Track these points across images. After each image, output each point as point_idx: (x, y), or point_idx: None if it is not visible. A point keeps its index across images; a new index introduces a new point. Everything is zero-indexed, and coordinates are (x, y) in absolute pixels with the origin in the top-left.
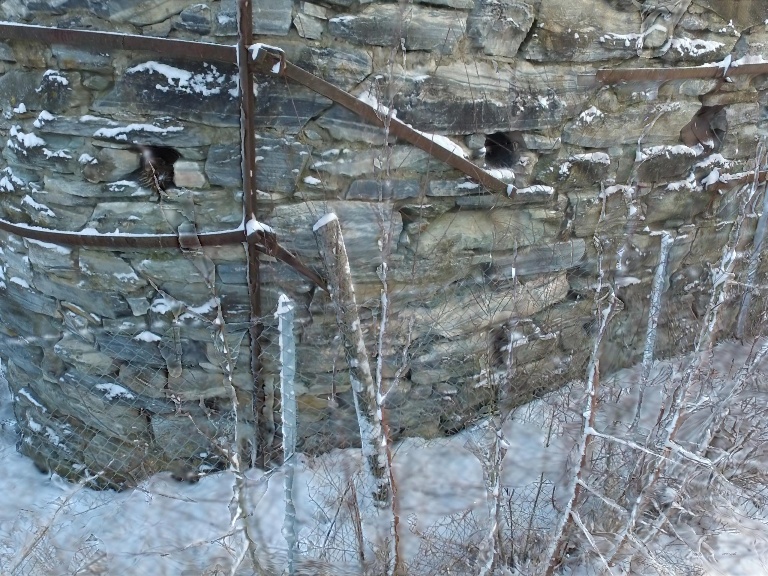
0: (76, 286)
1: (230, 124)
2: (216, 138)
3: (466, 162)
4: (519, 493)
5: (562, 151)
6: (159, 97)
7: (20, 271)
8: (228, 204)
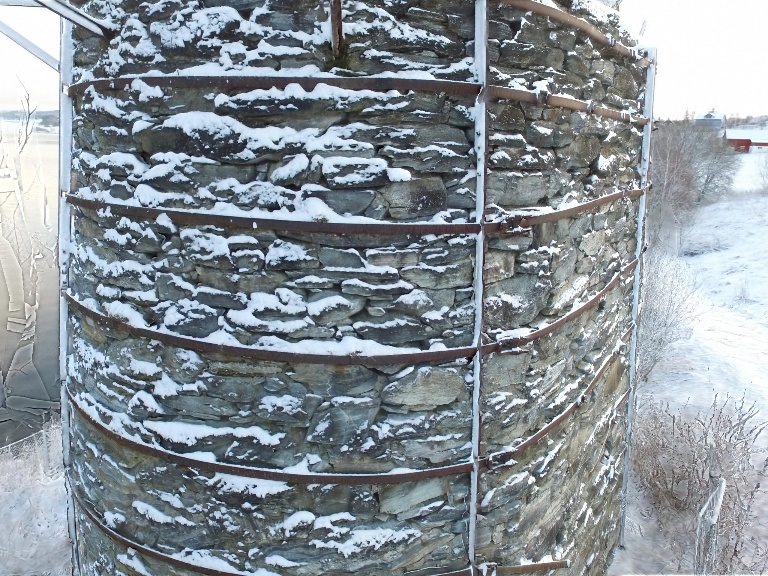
0: None
1: None
2: None
3: (554, 563)
4: None
5: None
6: None
7: None
8: None
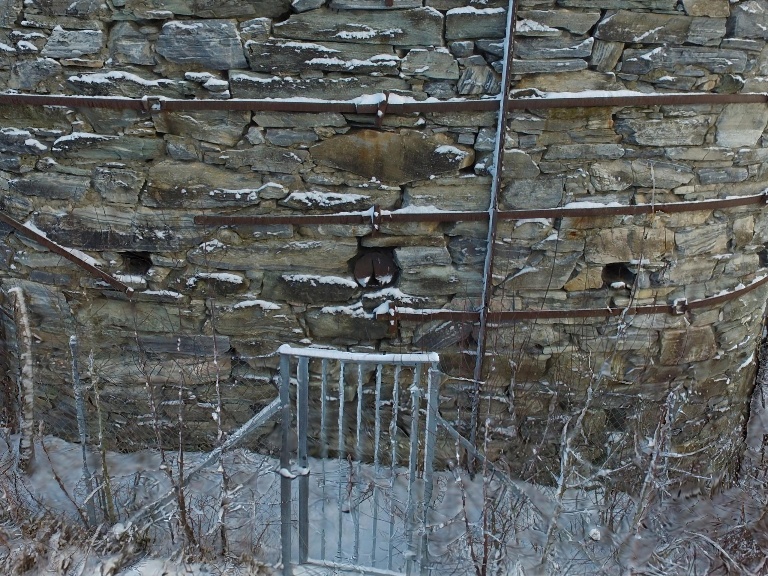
0: None
1: None
2: None
3: (95, 268)
4: (4, 477)
5: (191, 269)
6: None
7: None
8: None
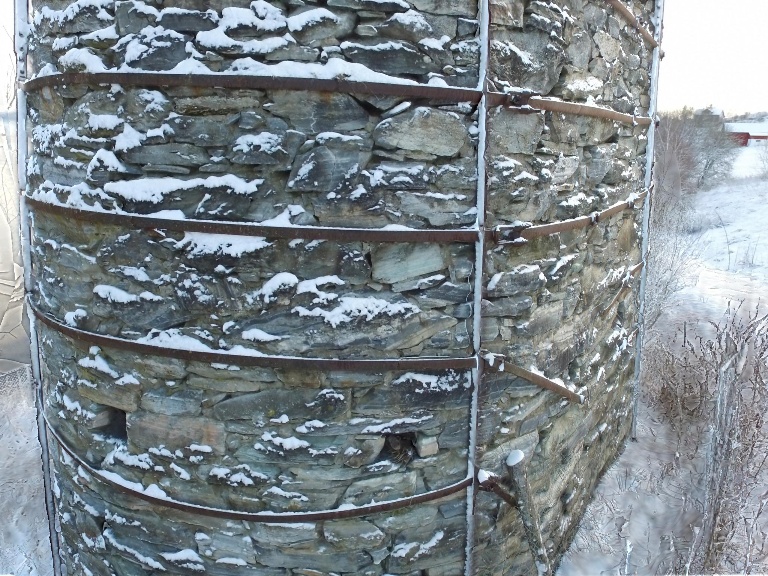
0: (317, 553)
1: (462, 406)
2: (450, 417)
3: (567, 390)
4: None
5: None
6: (418, 398)
7: (235, 551)
8: (452, 460)
